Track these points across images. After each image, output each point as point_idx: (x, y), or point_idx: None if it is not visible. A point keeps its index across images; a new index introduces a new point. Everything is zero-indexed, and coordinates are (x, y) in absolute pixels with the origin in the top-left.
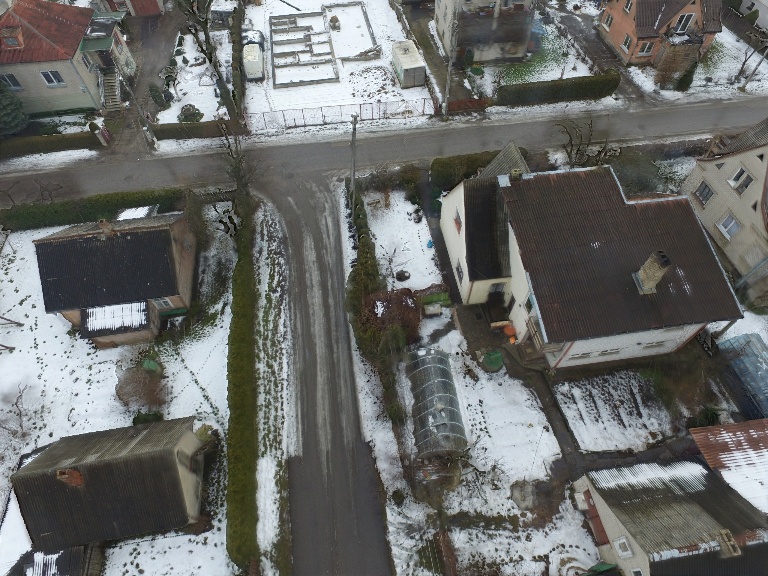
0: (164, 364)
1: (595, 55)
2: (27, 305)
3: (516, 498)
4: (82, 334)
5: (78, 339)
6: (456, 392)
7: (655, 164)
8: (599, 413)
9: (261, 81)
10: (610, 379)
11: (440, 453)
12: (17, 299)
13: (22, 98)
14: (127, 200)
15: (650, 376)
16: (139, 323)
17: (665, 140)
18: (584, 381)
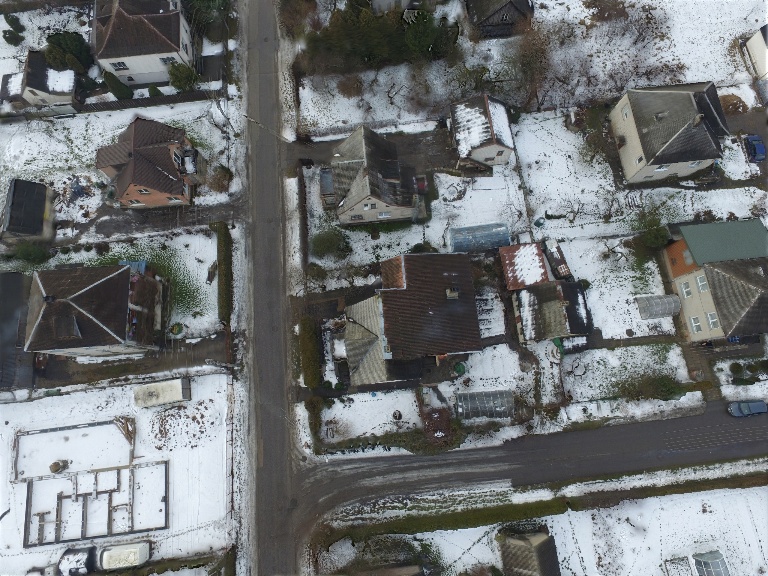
0: (458, 574)
1: (169, 223)
2: None
3: None
4: None
5: None
6: (478, 392)
7: (310, 226)
8: (486, 319)
9: (151, 544)
10: None
11: None
12: None
13: None
14: None
15: None
16: None
17: (287, 211)
18: None
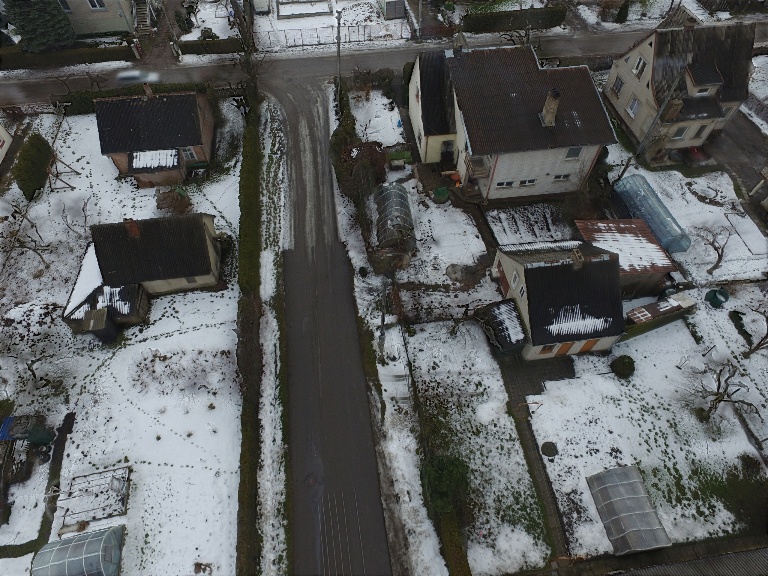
0: (190, 197)
1: None
2: (83, 162)
3: (449, 272)
4: (129, 170)
5: (124, 182)
6: (411, 213)
7: None
8: (518, 228)
9: (267, 14)
10: (529, 208)
11: (395, 243)
12: (74, 158)
13: (70, 20)
14: (159, 90)
15: (560, 207)
16: (172, 164)
17: None
18: (509, 209)
